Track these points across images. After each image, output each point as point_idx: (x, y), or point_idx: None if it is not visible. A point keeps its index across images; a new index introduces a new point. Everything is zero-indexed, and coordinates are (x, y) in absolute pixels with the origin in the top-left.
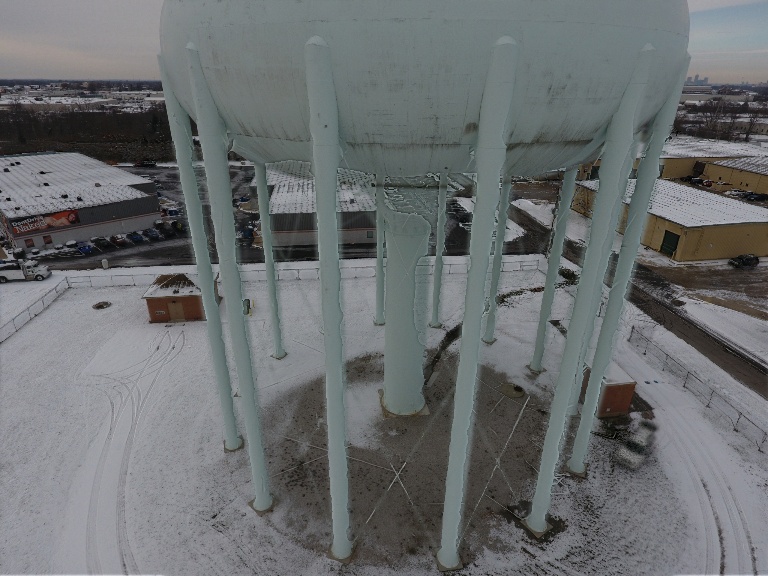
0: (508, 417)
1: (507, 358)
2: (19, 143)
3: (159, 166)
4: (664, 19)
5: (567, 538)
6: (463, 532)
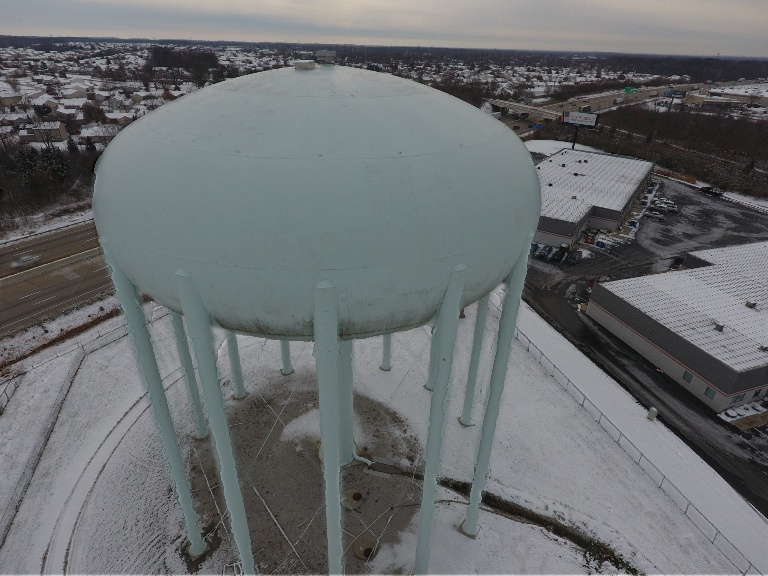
0: (322, 538)
1: (432, 547)
2: (645, 142)
3: (726, 197)
4: (116, 224)
5: (181, 571)
6: (201, 497)
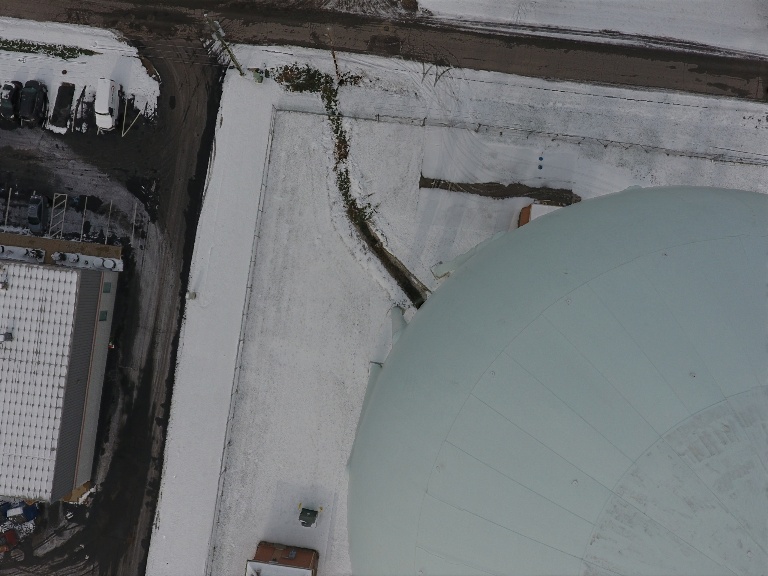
0: None
1: None
2: None
3: None
4: None
5: None
6: None
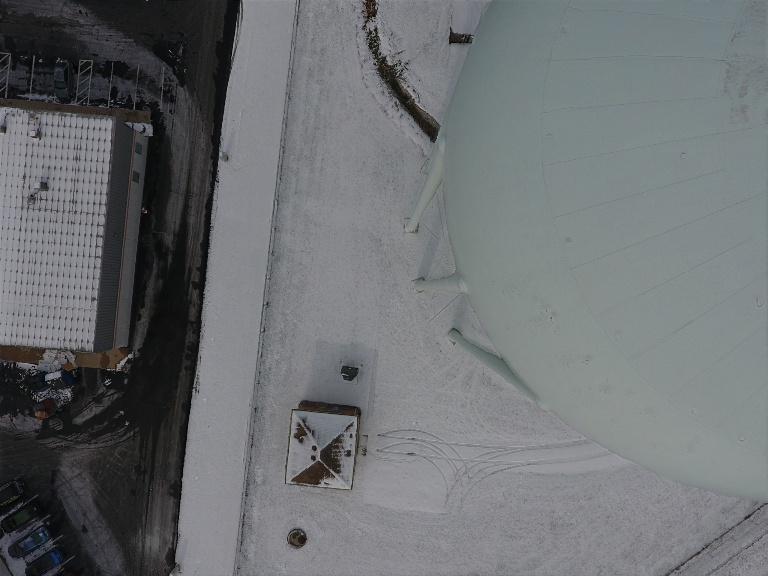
0: None
1: None
2: None
3: None
4: None
5: None
6: None
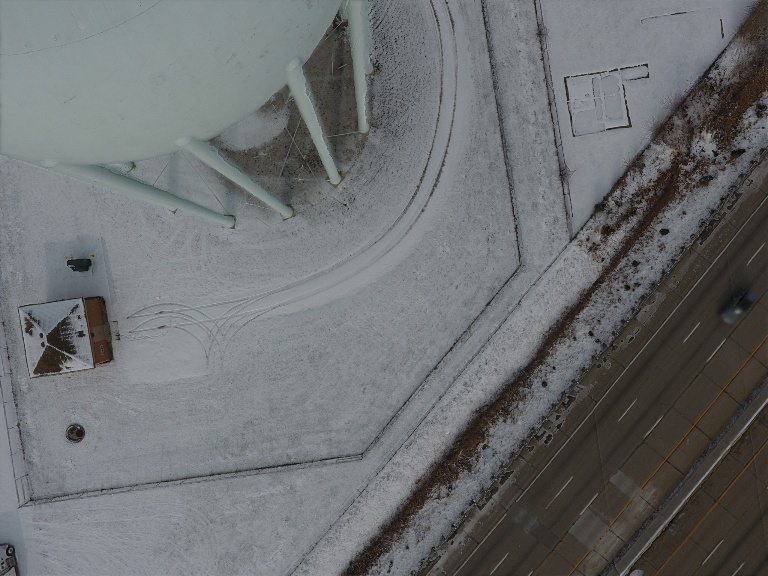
0: None
1: None
2: None
3: None
4: None
5: None
6: None
